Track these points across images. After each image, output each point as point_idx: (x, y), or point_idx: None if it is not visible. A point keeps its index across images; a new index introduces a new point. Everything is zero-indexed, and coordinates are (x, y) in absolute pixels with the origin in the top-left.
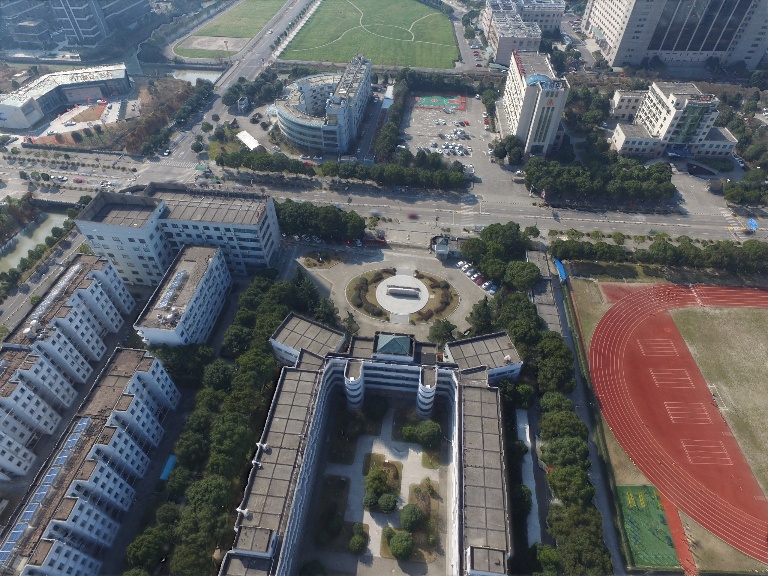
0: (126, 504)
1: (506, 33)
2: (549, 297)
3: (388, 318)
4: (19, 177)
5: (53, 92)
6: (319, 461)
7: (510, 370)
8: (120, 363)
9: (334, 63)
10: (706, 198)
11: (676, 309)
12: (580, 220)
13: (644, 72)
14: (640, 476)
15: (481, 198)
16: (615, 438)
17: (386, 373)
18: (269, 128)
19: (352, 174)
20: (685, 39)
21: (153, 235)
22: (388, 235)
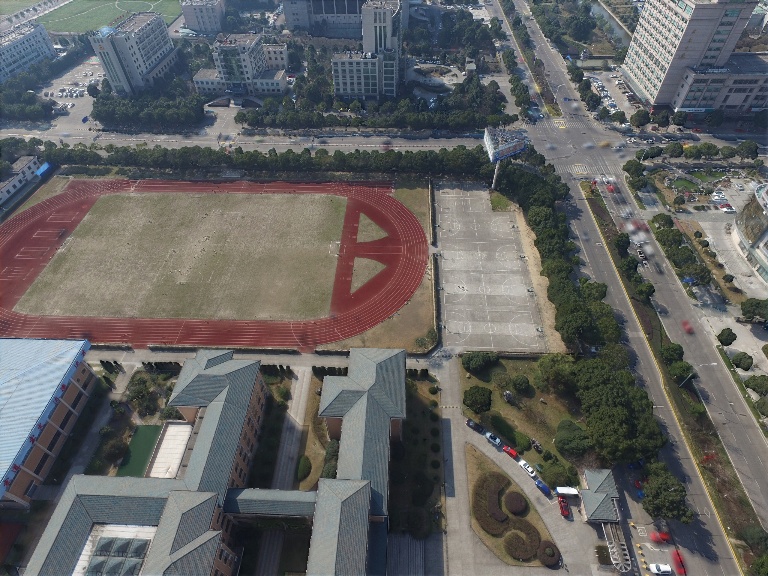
0: None
1: (189, 2)
2: (3, 184)
3: None
4: None
5: None
6: None
7: None
8: None
9: (57, 32)
10: (232, 123)
11: (108, 194)
12: (112, 139)
13: (297, 32)
14: None
15: (55, 126)
16: None
17: None
18: None
19: None
20: (341, 4)
21: None
22: None
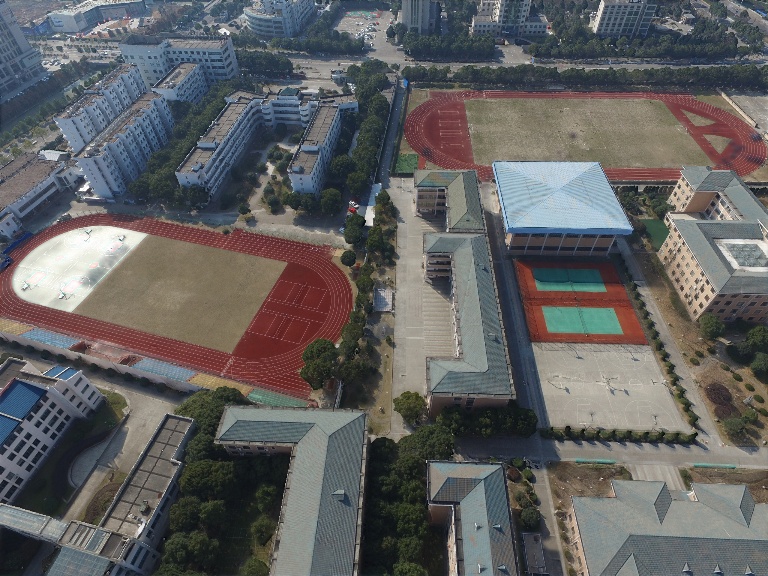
0: (149, 159)
1: None
2: (391, 91)
3: None
4: (76, 54)
5: (93, 10)
6: (248, 149)
7: (352, 108)
8: (145, 96)
9: None
10: (519, 56)
11: (469, 99)
12: None
13: None
14: (412, 151)
15: (373, 58)
16: (406, 141)
17: (285, 108)
18: None
19: (290, 45)
20: None
21: (162, 56)
22: (308, 74)
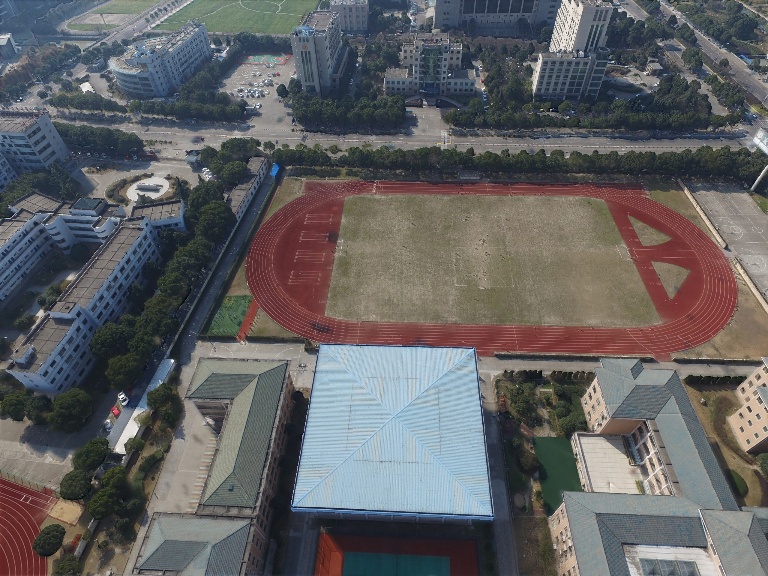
0: None
1: (338, 1)
2: (248, 186)
3: (127, 204)
4: None
5: None
6: (26, 284)
7: (173, 223)
8: None
9: None
10: (436, 124)
11: (352, 196)
12: (322, 140)
13: (452, 31)
14: (246, 290)
15: (253, 127)
16: (245, 270)
17: (81, 225)
18: (113, 81)
19: (151, 109)
20: (493, 3)
21: None
22: (163, 152)
